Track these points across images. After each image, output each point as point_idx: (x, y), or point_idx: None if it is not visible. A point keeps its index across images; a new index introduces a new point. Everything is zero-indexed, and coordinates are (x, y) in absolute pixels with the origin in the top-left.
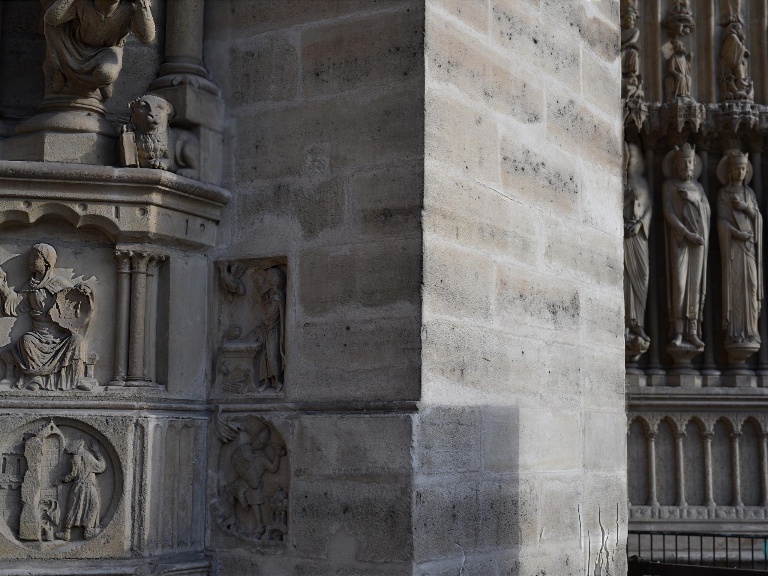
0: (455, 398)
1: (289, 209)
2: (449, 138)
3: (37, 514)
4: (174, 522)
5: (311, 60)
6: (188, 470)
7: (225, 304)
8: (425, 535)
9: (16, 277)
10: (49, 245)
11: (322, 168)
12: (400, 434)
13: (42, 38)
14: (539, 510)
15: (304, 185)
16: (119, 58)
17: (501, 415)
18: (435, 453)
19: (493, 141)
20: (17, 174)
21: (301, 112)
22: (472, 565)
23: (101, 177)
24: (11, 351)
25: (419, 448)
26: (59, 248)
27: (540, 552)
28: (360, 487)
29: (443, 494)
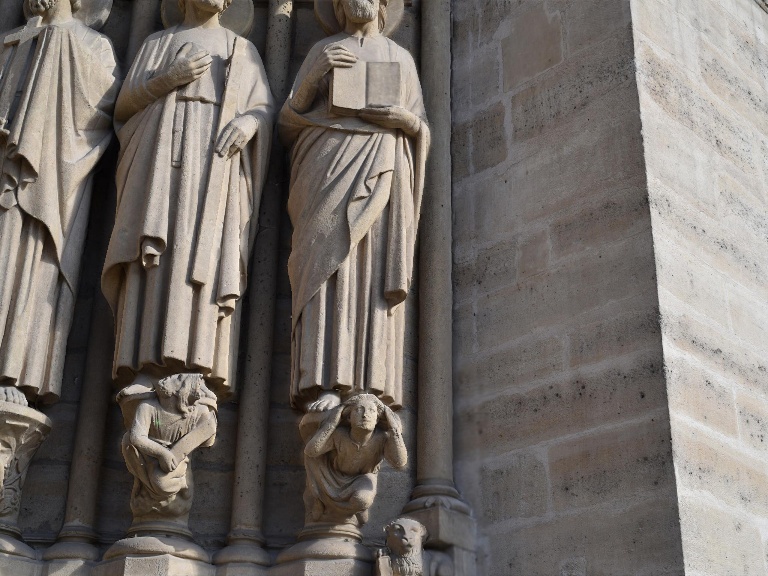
0: None
1: None
2: (709, 547)
3: None
4: None
5: (559, 475)
6: None
7: None
8: None
9: None
10: None
11: None
12: None
13: (302, 469)
14: None
15: None
16: (374, 484)
17: None
18: None
19: (756, 547)
20: None
21: (553, 527)
22: None
23: None
24: None
25: None
26: None
27: None
28: None
29: None
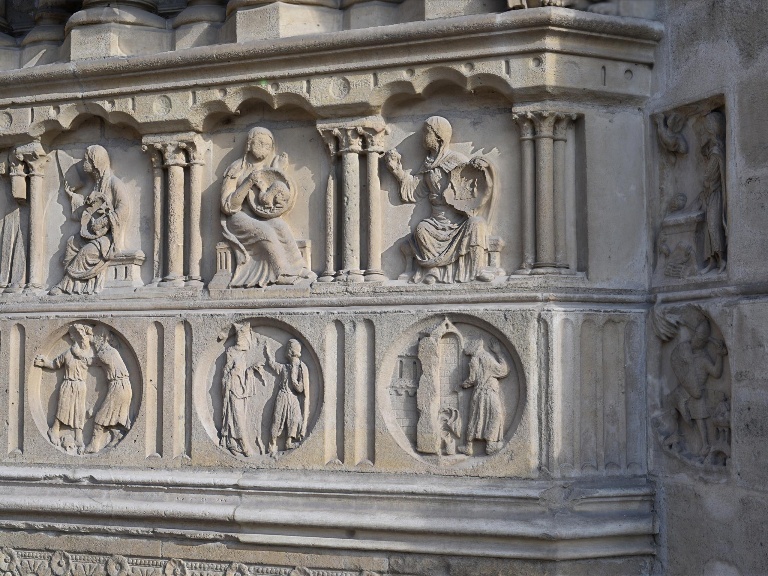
0: None
1: (724, 31)
2: None
3: (436, 424)
4: (598, 438)
5: None
6: (618, 375)
7: (668, 168)
8: None
9: (413, 158)
10: (442, 117)
11: None
12: None
13: None
14: None
15: None
16: None
17: None
18: None
19: None
20: (393, 39)
21: None
22: None
23: (482, 27)
24: (408, 241)
25: None
26: (456, 120)
27: None
28: None
29: None
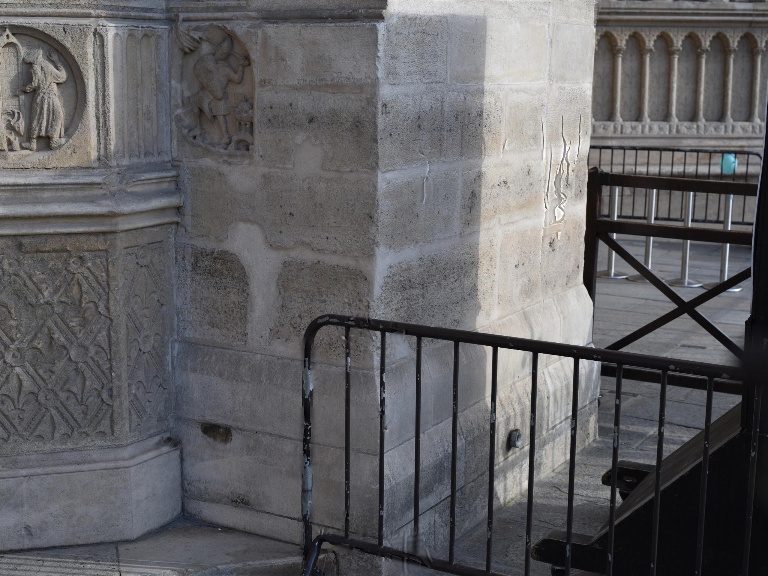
0: (422, 7)
1: None
2: None
3: (1, 124)
4: (140, 133)
5: None
6: (151, 81)
7: None
8: (390, 145)
9: None
10: None
11: None
12: (366, 43)
13: None
14: (503, 122)
15: None
16: None
17: (468, 25)
18: (401, 63)
19: None
20: None
21: None
22: (436, 174)
23: None
24: None
25: (385, 58)
26: None
27: (503, 162)
28: (325, 97)
29: (408, 105)
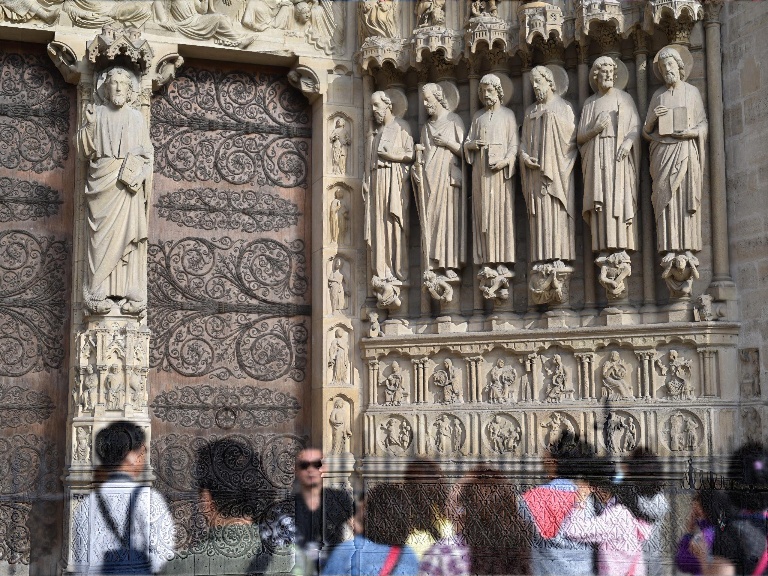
0: None
1: (758, 330)
2: None
3: (677, 442)
4: (726, 445)
5: (761, 274)
6: (731, 427)
7: (744, 365)
8: None
9: (665, 362)
10: (675, 350)
11: (767, 315)
12: None
13: None
14: None
15: (762, 321)
16: (690, 284)
17: None
18: None
19: None
20: (660, 328)
21: (760, 293)
22: None
23: (688, 326)
24: (665, 387)
25: None
26: (679, 351)
27: None
28: None
29: None
